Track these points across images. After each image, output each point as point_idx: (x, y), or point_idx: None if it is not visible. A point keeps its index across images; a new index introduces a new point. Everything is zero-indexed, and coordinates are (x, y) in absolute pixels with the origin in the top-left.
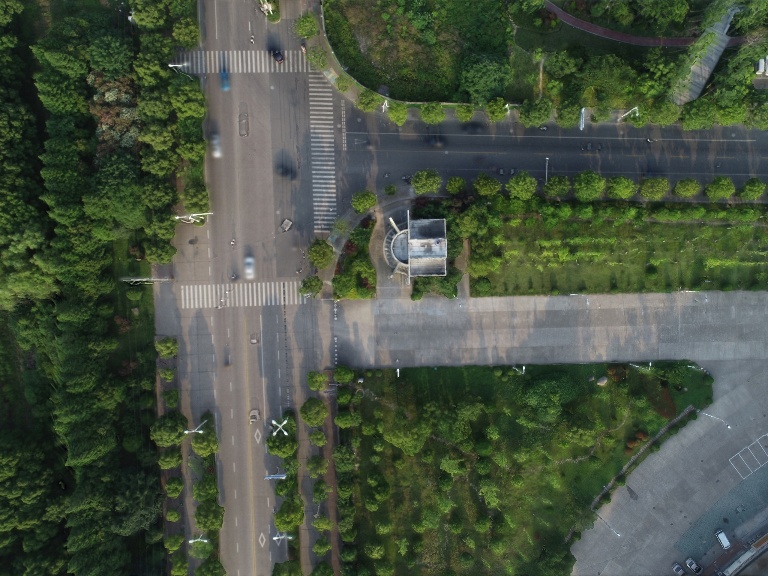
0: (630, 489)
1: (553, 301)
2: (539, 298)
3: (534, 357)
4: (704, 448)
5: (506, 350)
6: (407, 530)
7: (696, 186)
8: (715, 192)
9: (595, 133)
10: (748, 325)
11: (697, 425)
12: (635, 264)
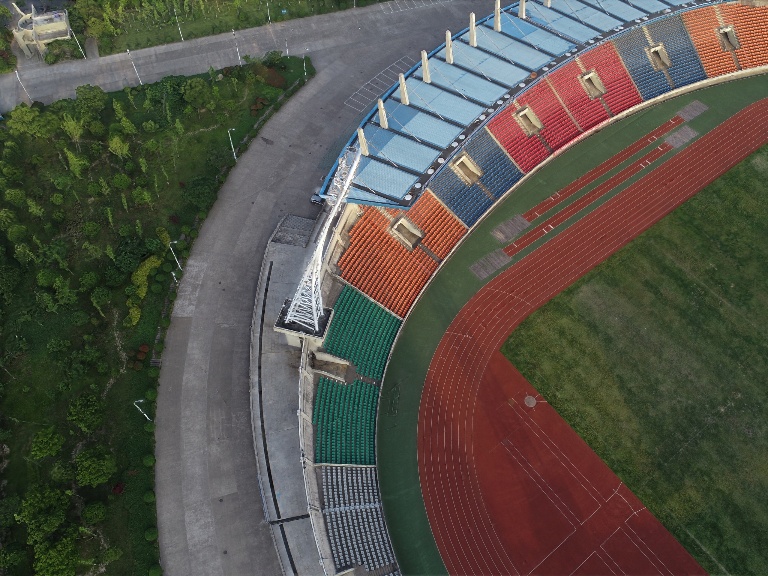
0: (265, 139)
1: (170, 47)
2: (158, 47)
3: (160, 78)
4: (320, 101)
5: (135, 79)
6: (49, 212)
7: None
8: None
9: None
10: (327, 30)
11: (309, 89)
12: (229, 16)
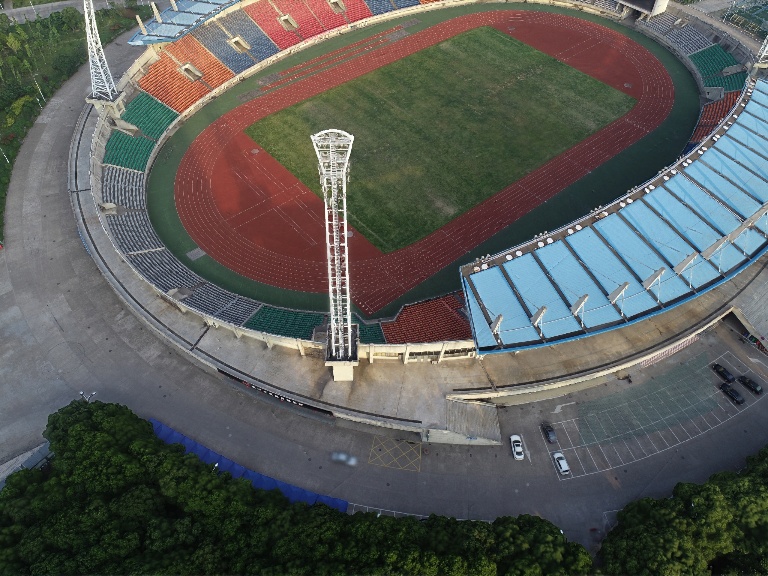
0: (117, 43)
1: (63, 2)
2: (54, 3)
3: None
4: None
5: (35, 18)
6: None
7: None
8: None
9: None
10: None
11: None
12: None
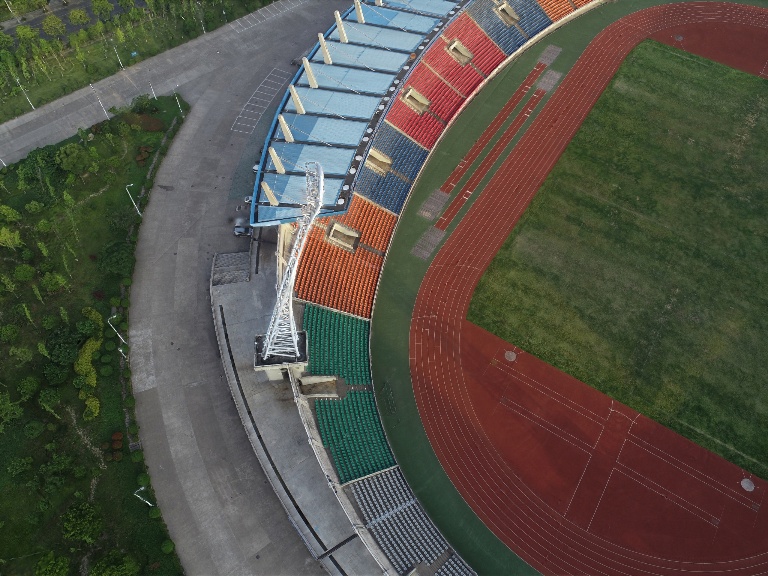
0: (163, 186)
1: (22, 119)
2: (8, 123)
3: (23, 155)
4: (205, 133)
5: None
6: None
7: (80, 11)
8: (95, 7)
9: (6, 34)
10: (186, 62)
11: (190, 125)
12: (75, 72)
